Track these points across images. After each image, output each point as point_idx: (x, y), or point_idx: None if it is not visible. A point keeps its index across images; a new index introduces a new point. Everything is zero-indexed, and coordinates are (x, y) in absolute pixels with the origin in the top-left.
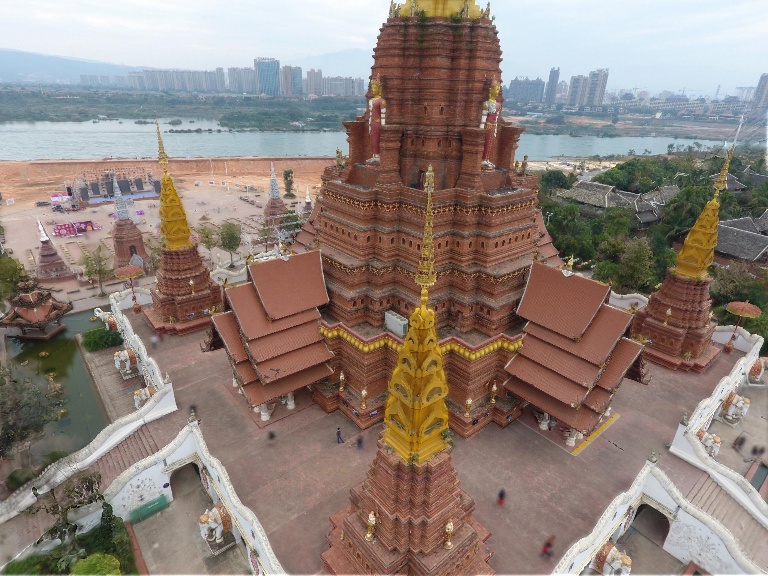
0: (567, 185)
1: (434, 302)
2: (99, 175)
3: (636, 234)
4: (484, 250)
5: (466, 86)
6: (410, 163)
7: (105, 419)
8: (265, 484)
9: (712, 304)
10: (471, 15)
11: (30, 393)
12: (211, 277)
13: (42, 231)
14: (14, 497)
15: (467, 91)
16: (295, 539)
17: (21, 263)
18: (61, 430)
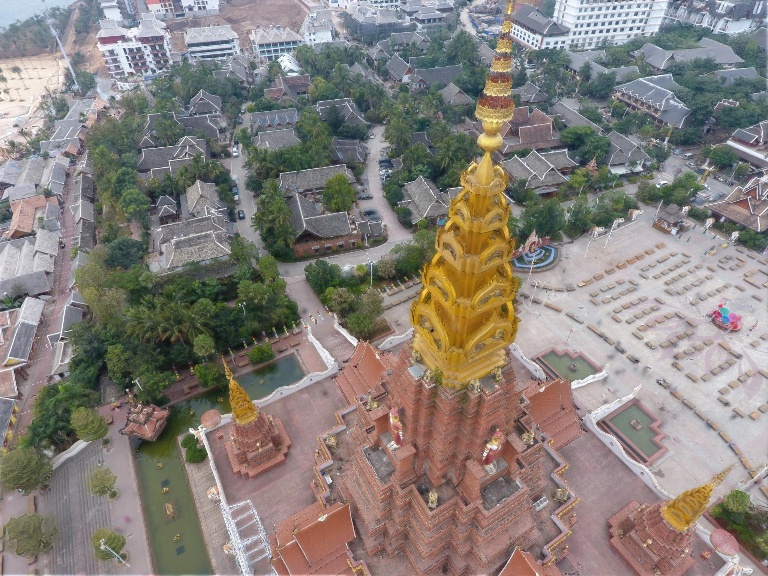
0: None
1: None
2: None
3: None
4: None
5: None
6: None
7: None
8: None
9: (379, 281)
10: None
11: None
12: None
13: None
14: None
15: None
16: None
17: None
18: None
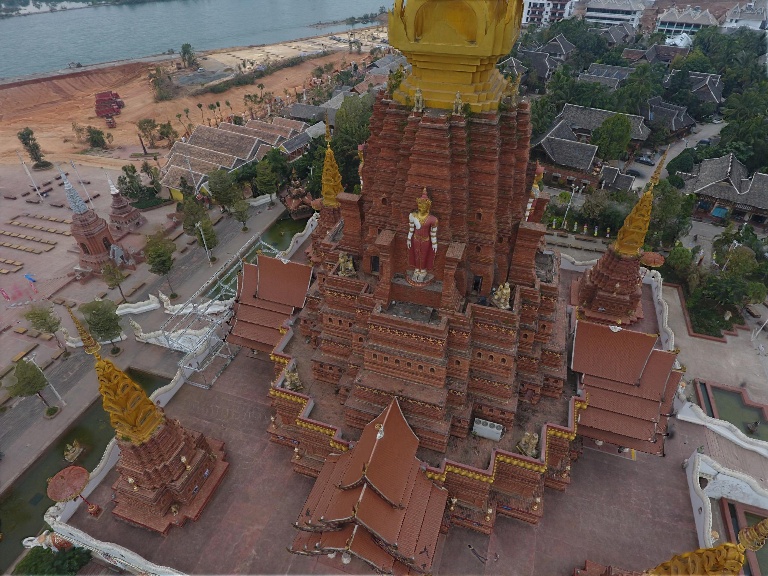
0: None
1: None
2: None
3: None
4: (545, 331)
5: (513, 178)
6: (464, 271)
7: None
8: None
9: (579, 223)
10: None
11: None
12: None
13: None
14: None
15: (514, 183)
16: None
17: None
18: None
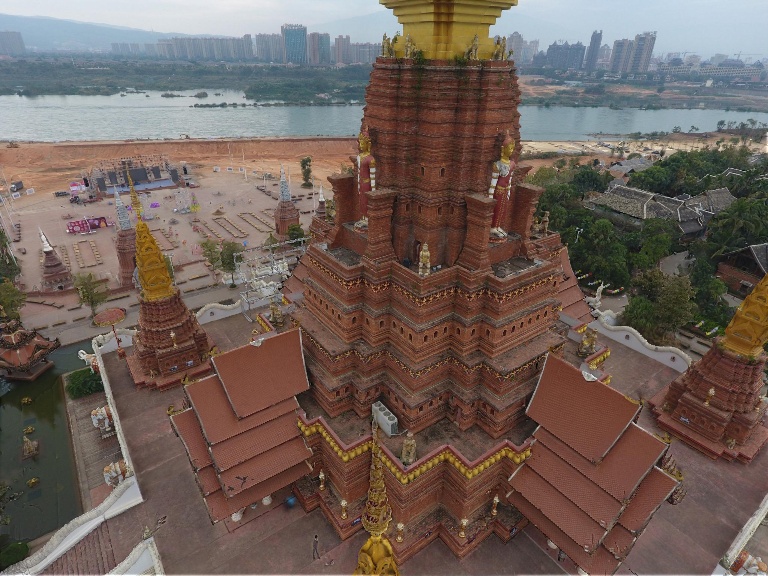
0: (602, 187)
1: (428, 398)
2: (116, 164)
3: (677, 246)
4: (489, 339)
5: (473, 143)
6: (404, 231)
7: (76, 492)
8: None
9: None
10: (482, 53)
11: None
12: (203, 313)
13: (45, 241)
14: None
15: (474, 149)
16: None
17: (32, 266)
18: (30, 504)
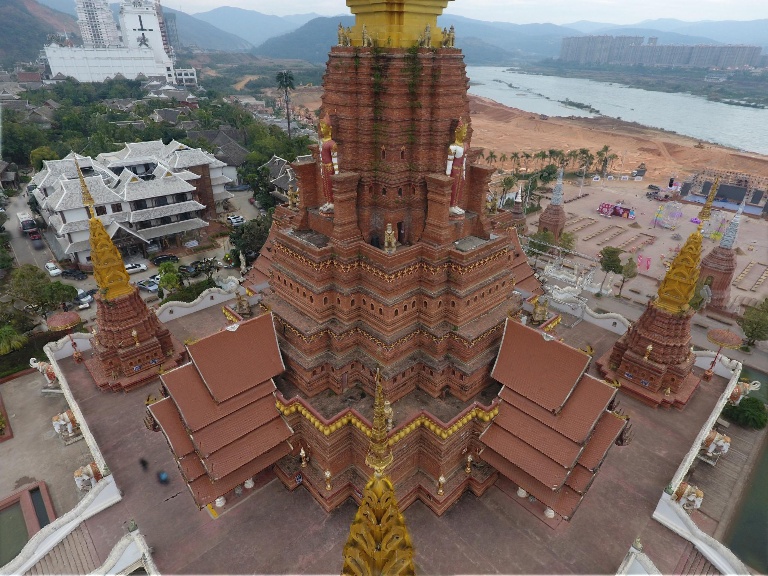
0: None
1: None
2: None
3: None
4: None
5: None
6: None
7: None
8: (211, 315)
9: None
10: None
11: (255, 230)
12: None
13: (520, 194)
14: (246, 268)
15: None
16: (170, 328)
17: None
18: None
